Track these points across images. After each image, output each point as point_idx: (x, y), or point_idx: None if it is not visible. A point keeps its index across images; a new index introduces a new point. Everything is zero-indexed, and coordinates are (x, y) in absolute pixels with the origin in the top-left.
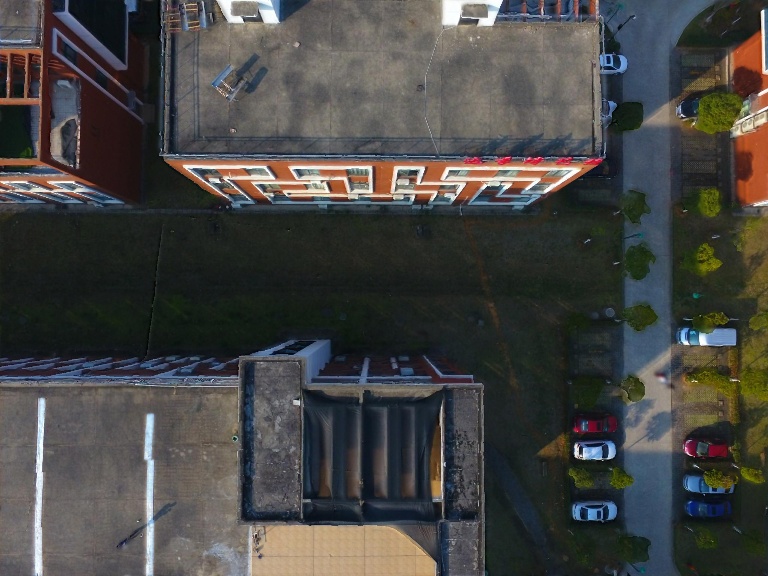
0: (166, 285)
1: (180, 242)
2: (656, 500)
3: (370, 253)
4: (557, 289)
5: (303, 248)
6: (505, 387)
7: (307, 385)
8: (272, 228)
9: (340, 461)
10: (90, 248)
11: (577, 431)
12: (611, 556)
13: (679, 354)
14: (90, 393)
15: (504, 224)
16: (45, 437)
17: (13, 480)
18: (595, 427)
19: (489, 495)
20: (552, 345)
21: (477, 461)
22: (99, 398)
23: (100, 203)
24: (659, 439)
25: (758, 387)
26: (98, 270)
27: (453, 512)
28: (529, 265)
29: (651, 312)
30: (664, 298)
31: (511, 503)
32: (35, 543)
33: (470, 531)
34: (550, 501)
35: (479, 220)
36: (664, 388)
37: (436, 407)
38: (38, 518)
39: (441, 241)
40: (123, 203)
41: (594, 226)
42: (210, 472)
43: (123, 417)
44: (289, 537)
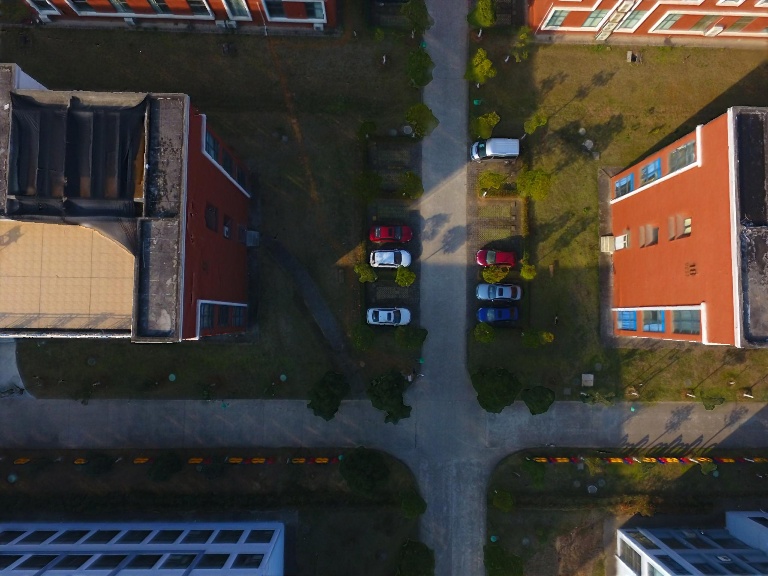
0: None
1: None
2: (451, 310)
3: (177, 69)
4: (358, 107)
5: (111, 62)
6: (306, 199)
7: (16, 90)
8: (82, 43)
9: (45, 161)
10: None
11: (372, 239)
12: (406, 362)
13: (475, 172)
14: None
15: (307, 45)
16: None
17: None
18: (387, 233)
19: (289, 303)
20: (351, 159)
21: (180, 166)
22: None
23: None
24: (454, 251)
25: (528, 183)
26: None
27: (155, 213)
28: (331, 84)
29: (422, 106)
30: (461, 119)
31: (310, 310)
32: None
33: (171, 231)
34: (347, 308)
35: (283, 40)
36: (460, 203)
37: (141, 113)
38: None
39: (246, 59)
40: None
41: (394, 48)
42: None
43: None
44: (17, 258)
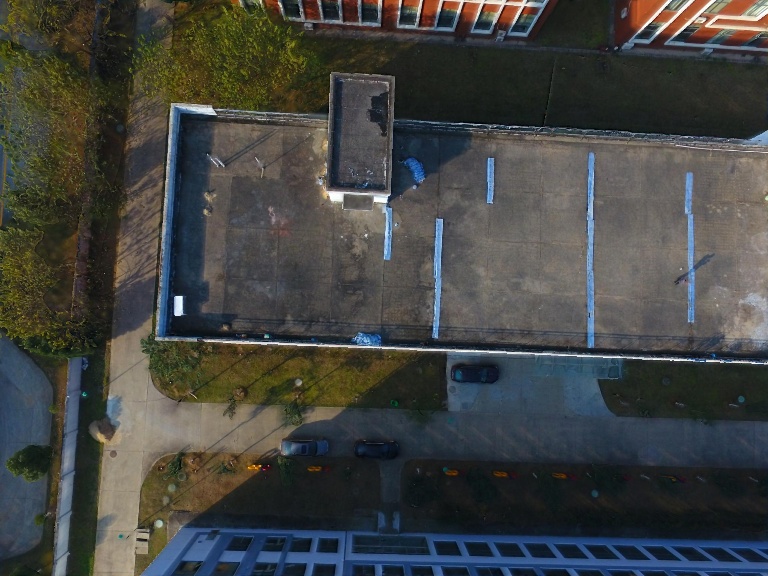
0: (554, 119)
1: (570, 78)
2: None
3: (744, 99)
4: None
5: (683, 91)
6: None
7: None
8: (655, 71)
9: None
10: (486, 79)
11: None
12: None
13: None
14: (635, 151)
15: None
16: (595, 188)
17: (567, 226)
18: None
19: None
20: None
21: None
22: (643, 156)
23: (505, 35)
24: None
25: None
26: (493, 100)
27: None
28: None
29: None
30: None
31: None
32: (587, 285)
33: None
34: None
35: None
36: None
37: None
38: (589, 262)
39: None
40: (526, 36)
41: None
42: (744, 228)
43: (665, 174)
44: None
